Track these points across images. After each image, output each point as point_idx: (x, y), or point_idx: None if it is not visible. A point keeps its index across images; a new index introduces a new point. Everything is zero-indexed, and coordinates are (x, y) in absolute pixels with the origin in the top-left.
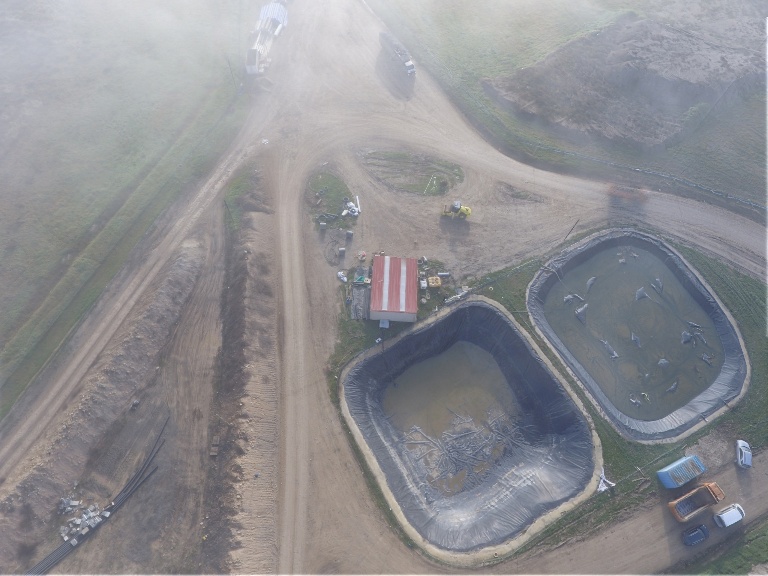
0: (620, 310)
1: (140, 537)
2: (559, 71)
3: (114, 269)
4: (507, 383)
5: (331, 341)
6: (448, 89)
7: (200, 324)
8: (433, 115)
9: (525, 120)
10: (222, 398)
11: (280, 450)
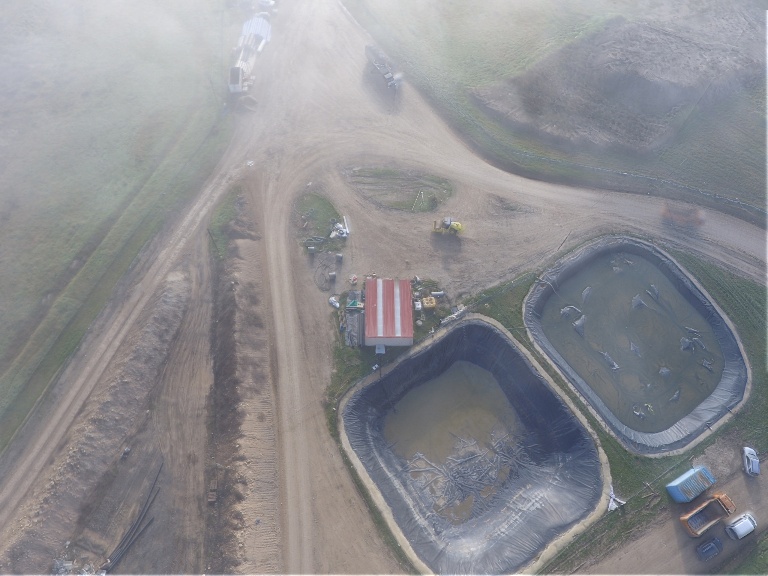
0: (617, 319)
1: None
2: (540, 76)
3: (96, 309)
4: (509, 402)
5: (327, 371)
6: (430, 100)
7: (190, 362)
8: (416, 128)
9: (509, 128)
10: (217, 439)
11: (281, 490)
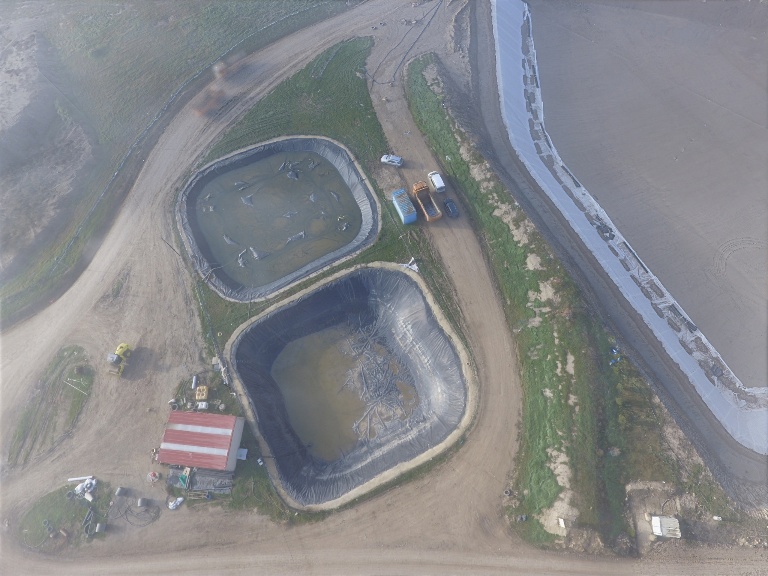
0: (260, 221)
1: None
2: None
3: None
4: (318, 332)
5: (254, 519)
6: None
7: None
8: None
9: (20, 269)
10: None
11: None
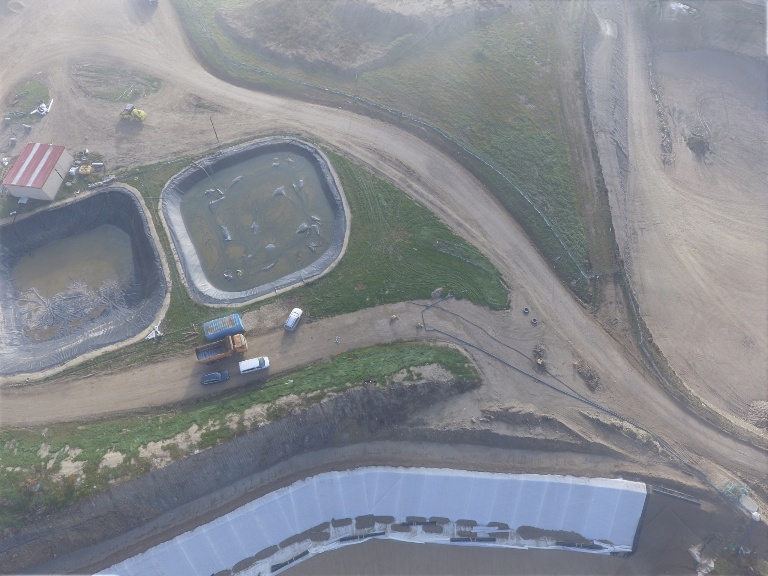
0: (253, 203)
1: None
2: (292, 4)
3: None
4: (132, 259)
5: None
6: (183, 17)
7: None
8: (159, 38)
9: (240, 44)
10: None
11: None
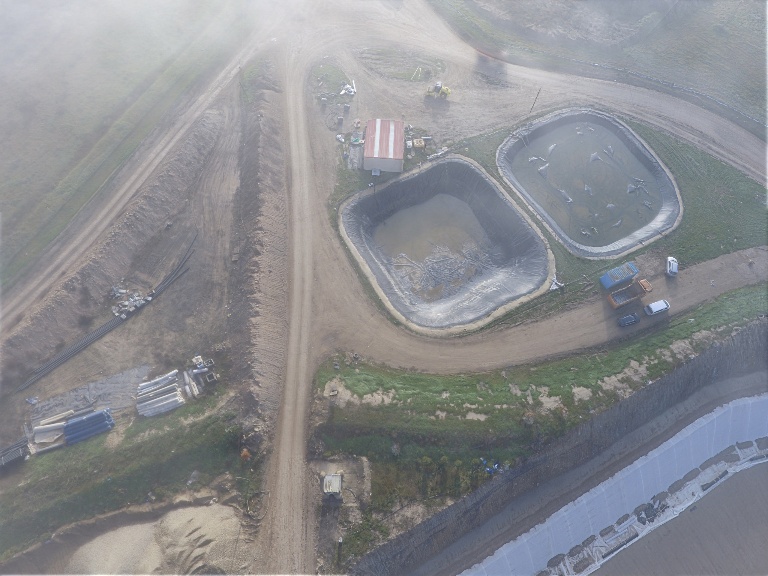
0: (576, 169)
1: (177, 315)
2: None
3: (148, 129)
4: (479, 224)
5: (331, 184)
6: (433, 2)
7: (221, 171)
8: (420, 22)
9: (500, 26)
10: (241, 221)
11: (289, 258)
